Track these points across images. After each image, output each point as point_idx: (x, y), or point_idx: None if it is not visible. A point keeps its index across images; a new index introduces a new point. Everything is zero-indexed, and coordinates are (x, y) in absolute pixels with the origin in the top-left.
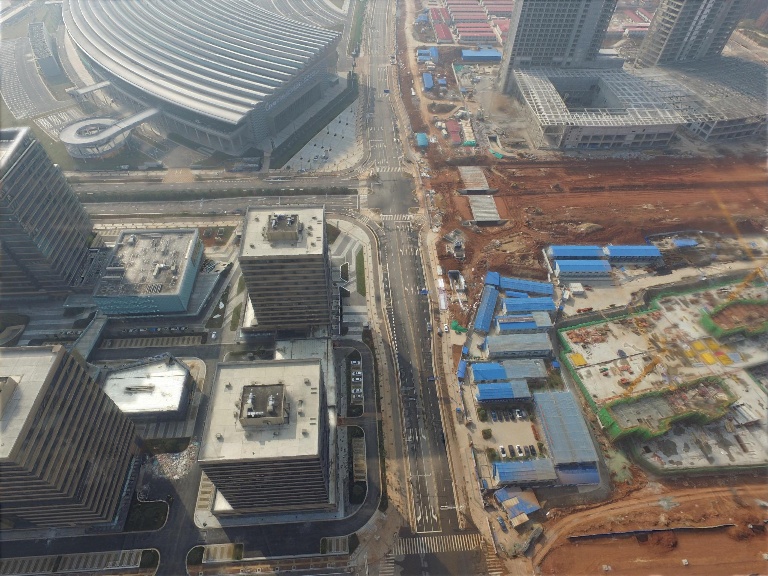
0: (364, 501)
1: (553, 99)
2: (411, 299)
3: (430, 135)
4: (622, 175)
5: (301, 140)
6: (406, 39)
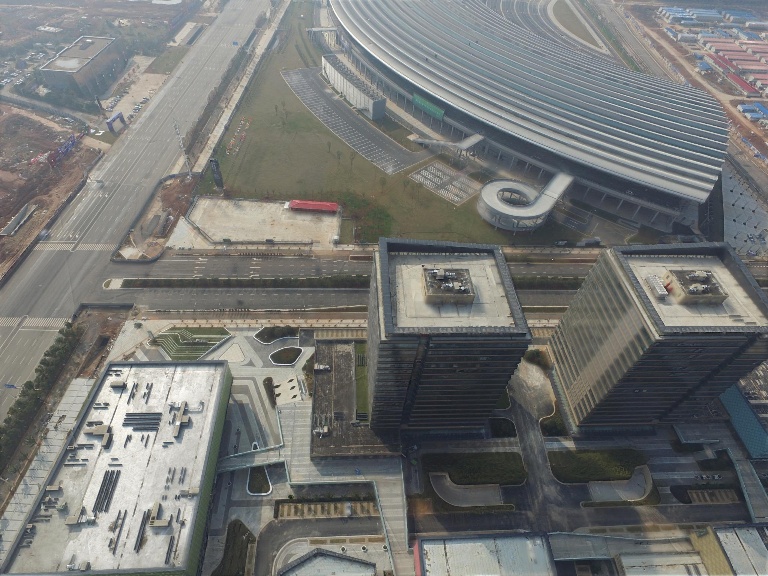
0: None
1: None
2: None
3: None
4: None
5: (715, 213)
6: (709, 90)
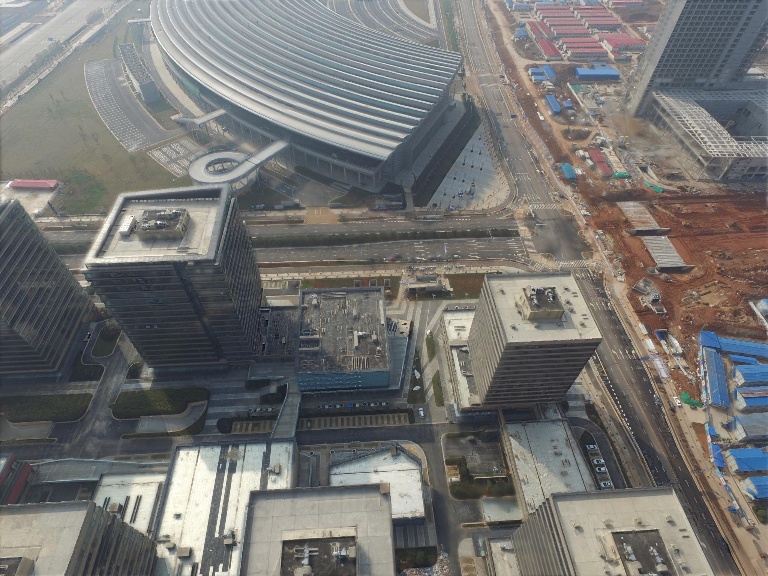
0: None
1: (712, 126)
2: (624, 365)
3: (574, 165)
4: None
5: (438, 173)
6: (511, 56)
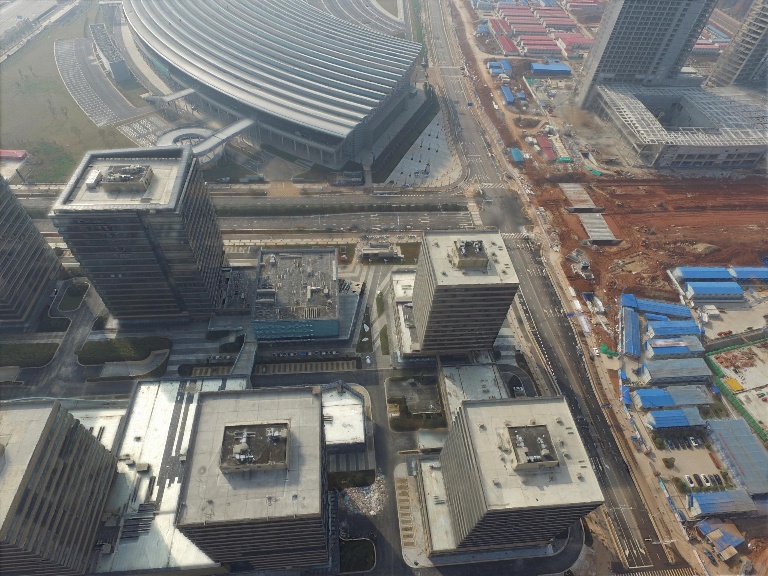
0: (569, 535)
1: (646, 117)
2: (553, 321)
3: (523, 150)
4: (719, 194)
5: (397, 153)
6: (472, 50)
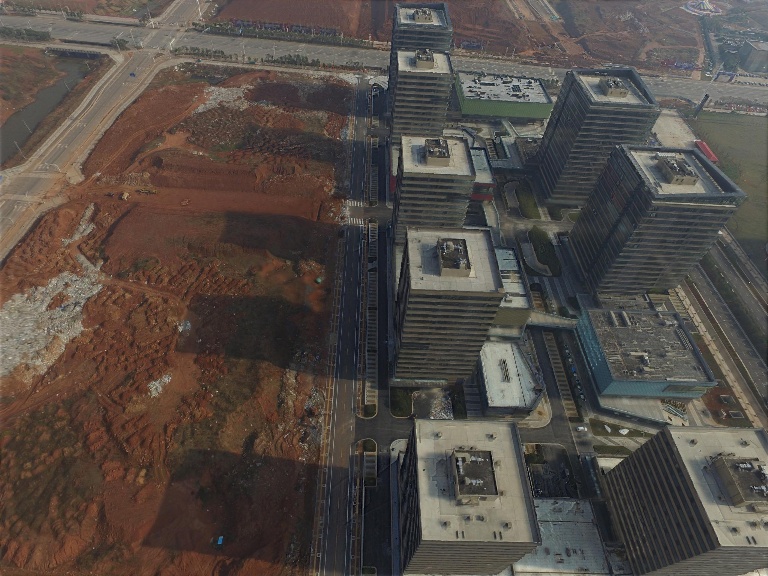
0: None
1: None
2: None
3: None
4: None
5: None
6: None
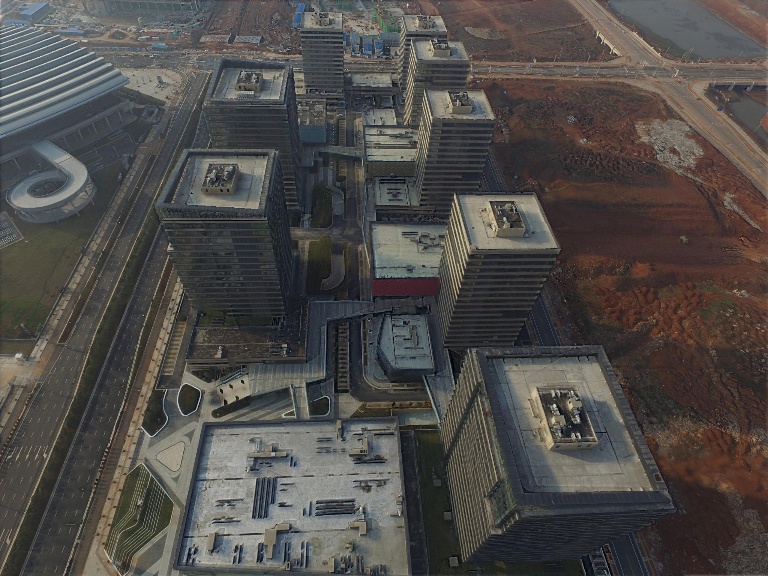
0: None
1: None
2: None
3: None
4: (233, 2)
5: None
6: None
